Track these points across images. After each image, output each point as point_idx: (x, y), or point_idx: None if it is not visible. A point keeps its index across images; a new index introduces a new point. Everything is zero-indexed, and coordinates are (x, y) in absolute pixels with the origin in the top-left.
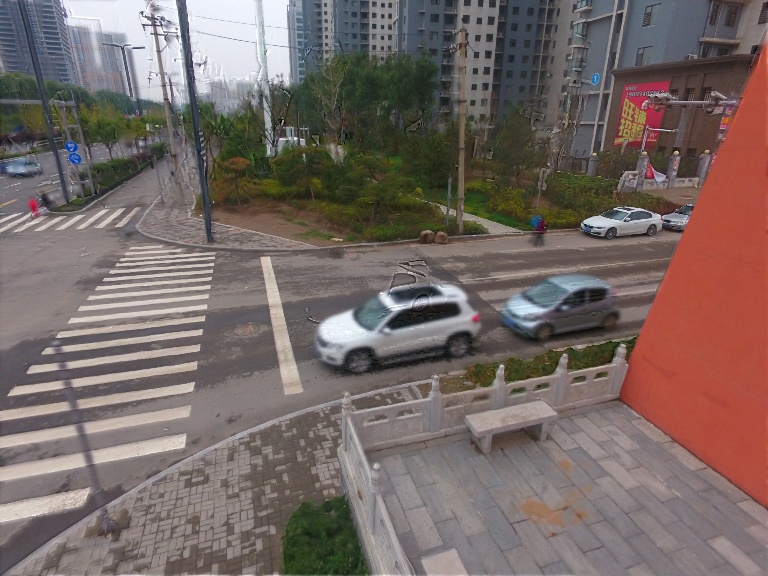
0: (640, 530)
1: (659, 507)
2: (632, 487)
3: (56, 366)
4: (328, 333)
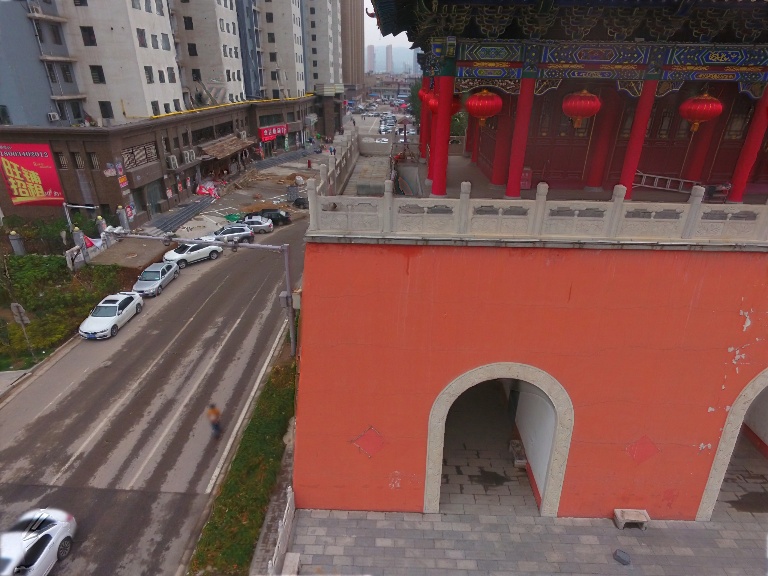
0: (362, 567)
1: (356, 549)
2: (343, 551)
3: None
4: None
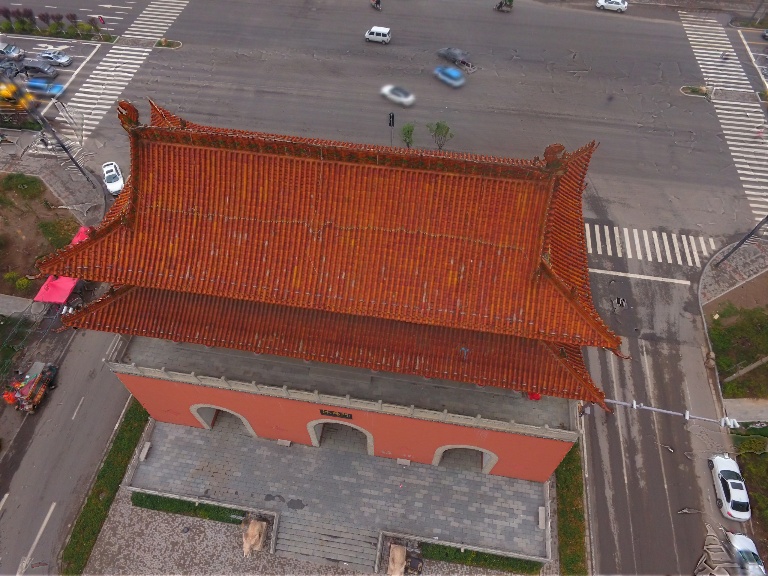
0: None
1: None
2: None
3: (597, 229)
4: (601, 282)
